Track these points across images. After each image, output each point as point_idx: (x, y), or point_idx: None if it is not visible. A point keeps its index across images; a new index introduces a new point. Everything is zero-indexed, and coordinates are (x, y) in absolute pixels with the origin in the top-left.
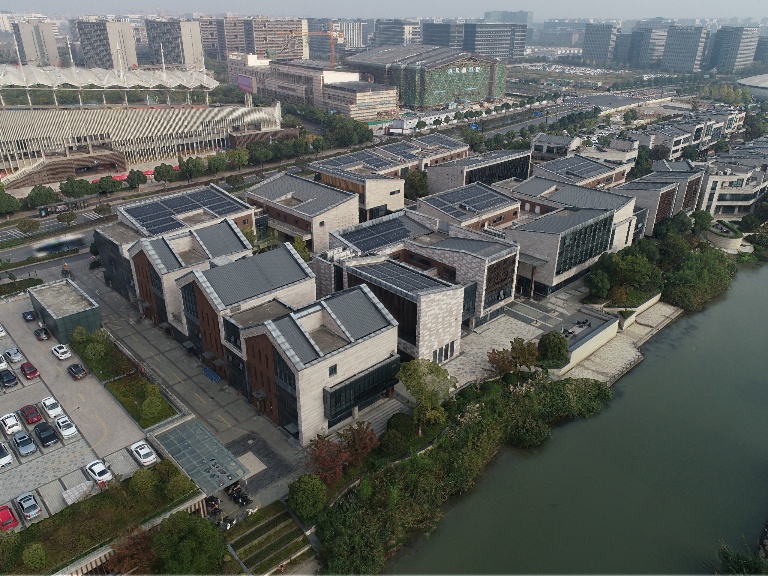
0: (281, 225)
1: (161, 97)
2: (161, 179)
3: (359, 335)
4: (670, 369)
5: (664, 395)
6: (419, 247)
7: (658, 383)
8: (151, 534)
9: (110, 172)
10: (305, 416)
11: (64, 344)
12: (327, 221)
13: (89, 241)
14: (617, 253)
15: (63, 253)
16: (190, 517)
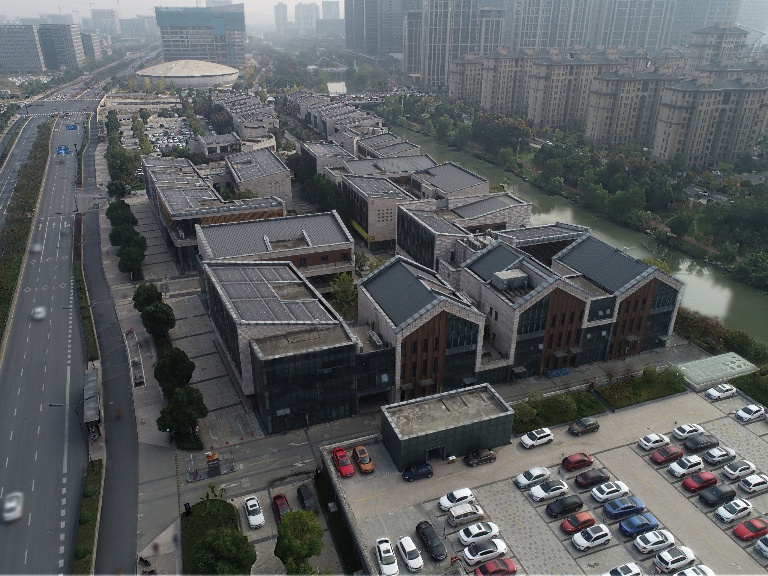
0: (307, 270)
1: None
2: None
3: None
4: None
5: None
6: (471, 220)
7: None
8: None
9: None
10: None
11: (509, 441)
12: None
13: (51, 453)
14: None
15: (98, 477)
16: None
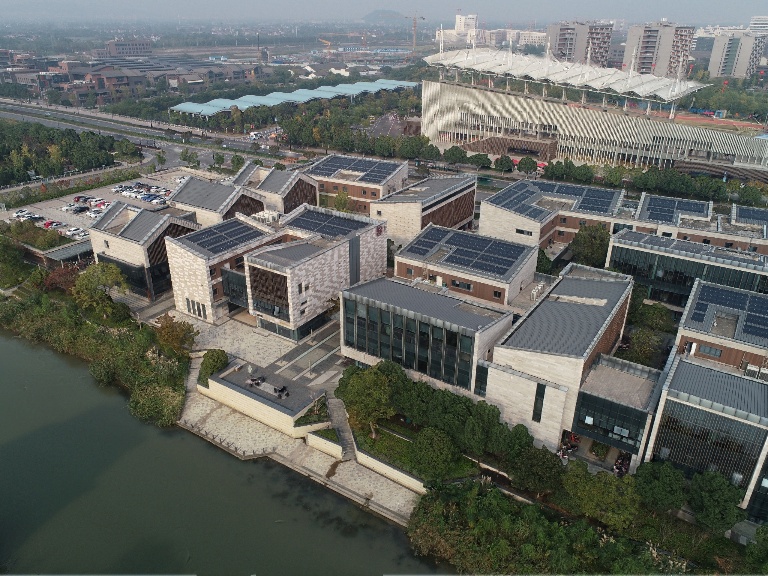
0: None
1: (620, 102)
2: (520, 170)
3: (127, 236)
4: (219, 482)
5: (158, 466)
6: None
7: (189, 469)
8: (19, 247)
9: (537, 159)
10: (97, 261)
11: None
12: (385, 213)
13: None
14: None
15: None
16: (3, 240)
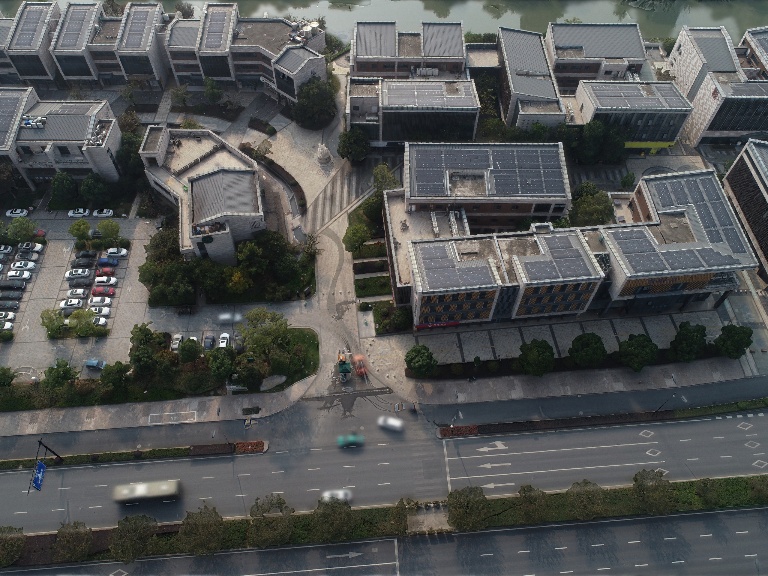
0: None
1: None
2: None
3: None
4: None
5: None
6: None
7: None
8: None
9: None
10: None
11: None
12: None
13: None
14: None
15: None
16: None
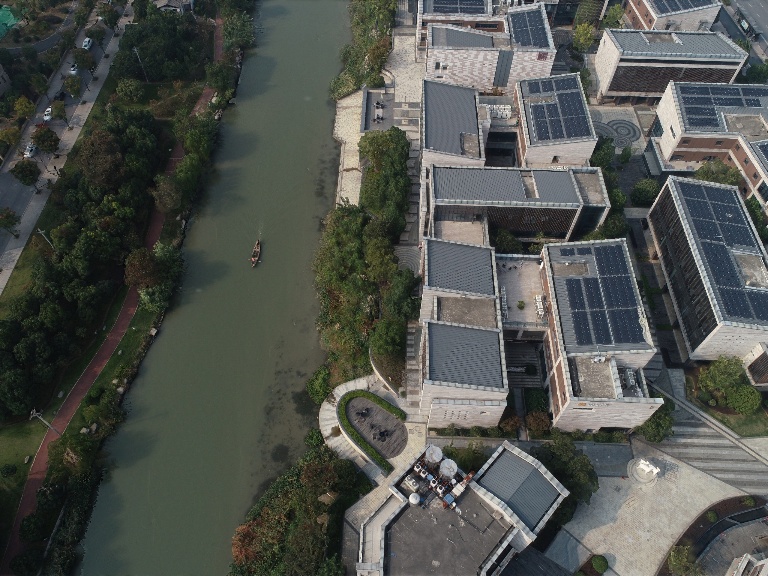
0: None
1: None
2: None
3: None
4: (314, 138)
5: (307, 113)
6: None
7: (315, 124)
8: None
9: None
10: None
11: None
12: None
13: (752, 15)
14: (399, 156)
15: None
16: None
